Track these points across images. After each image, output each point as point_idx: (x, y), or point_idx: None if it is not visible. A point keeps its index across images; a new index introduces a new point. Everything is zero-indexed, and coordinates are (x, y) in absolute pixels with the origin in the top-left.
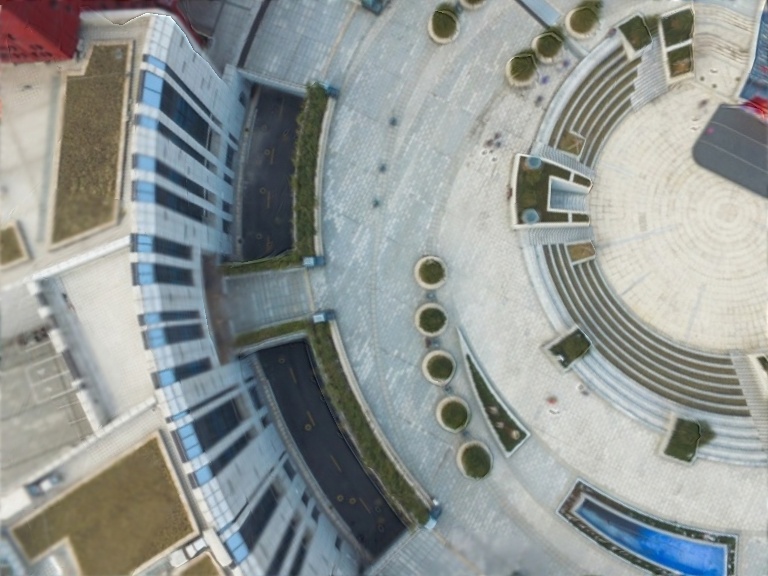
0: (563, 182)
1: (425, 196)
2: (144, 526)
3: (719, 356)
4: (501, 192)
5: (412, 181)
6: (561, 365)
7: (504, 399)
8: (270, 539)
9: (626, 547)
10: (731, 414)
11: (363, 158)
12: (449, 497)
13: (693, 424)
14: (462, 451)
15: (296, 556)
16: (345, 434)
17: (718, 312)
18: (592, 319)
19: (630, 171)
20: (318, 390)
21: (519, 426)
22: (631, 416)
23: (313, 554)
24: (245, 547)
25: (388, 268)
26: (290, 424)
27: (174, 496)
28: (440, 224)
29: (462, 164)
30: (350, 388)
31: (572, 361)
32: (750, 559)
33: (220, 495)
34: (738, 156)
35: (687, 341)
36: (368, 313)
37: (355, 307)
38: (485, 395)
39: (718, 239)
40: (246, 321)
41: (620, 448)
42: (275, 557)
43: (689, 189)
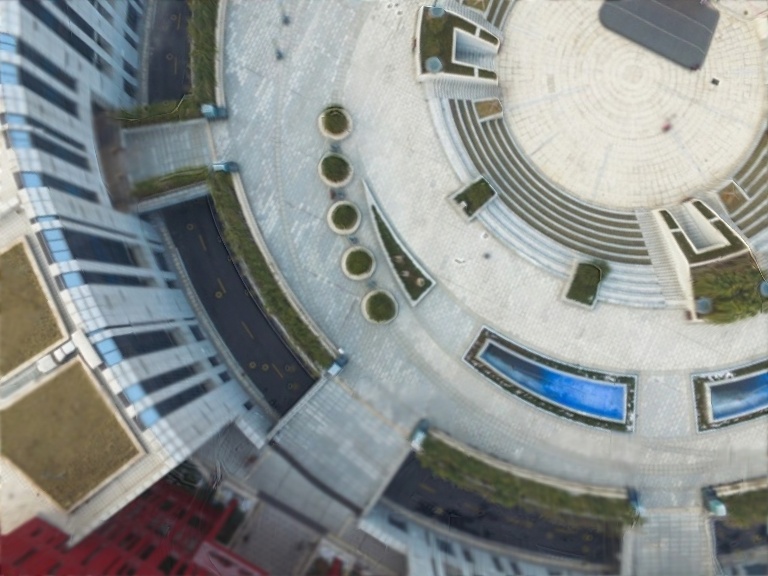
0: (468, 36)
1: (330, 49)
2: (10, 333)
3: (624, 213)
4: (406, 45)
5: (316, 34)
6: (466, 214)
7: (410, 249)
8: (155, 363)
9: (529, 389)
10: (633, 263)
11: (266, 10)
12: (356, 348)
13: (593, 267)
14: (366, 298)
15: (188, 389)
16: (248, 284)
17: (624, 171)
18: (499, 174)
19: (538, 33)
20: (225, 250)
21: (424, 275)
22: (535, 263)
23: (212, 397)
24: (119, 354)
25: (292, 121)
26: (200, 292)
27: (42, 302)
28: (345, 77)
29: (367, 17)
30: (253, 239)
31: (476, 210)
32: (649, 398)
33: (92, 301)
34: (642, 18)
35: (594, 200)
36: (272, 166)
37: (259, 160)
38: (390, 245)
39: (624, 100)
40: (145, 175)
41: (524, 295)
42: (159, 377)
43: (596, 51)
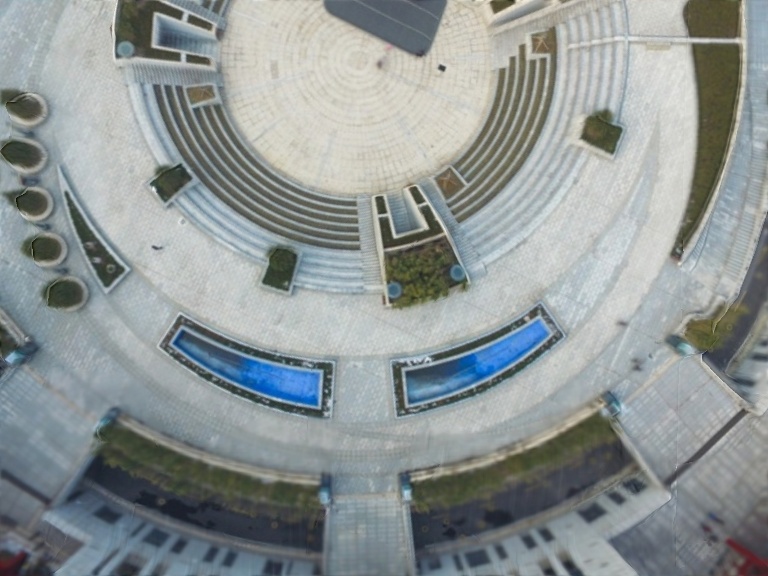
0: (173, 21)
1: (28, 34)
2: None
3: (346, 199)
4: (107, 30)
5: (14, 19)
6: (161, 200)
7: (105, 236)
8: None
9: (223, 376)
10: (341, 248)
11: None
12: (48, 336)
13: (287, 252)
14: (51, 285)
15: None
16: None
17: (348, 157)
18: (208, 160)
19: (262, 19)
20: None
21: (118, 261)
22: (232, 249)
23: None
24: None
25: None
26: None
27: None
28: (43, 62)
29: (68, 2)
30: None
31: (172, 195)
32: (347, 383)
33: None
34: (367, 4)
35: (317, 186)
36: None
37: None
38: (83, 231)
39: (349, 86)
40: None
41: (222, 281)
42: None
43: (321, 37)
